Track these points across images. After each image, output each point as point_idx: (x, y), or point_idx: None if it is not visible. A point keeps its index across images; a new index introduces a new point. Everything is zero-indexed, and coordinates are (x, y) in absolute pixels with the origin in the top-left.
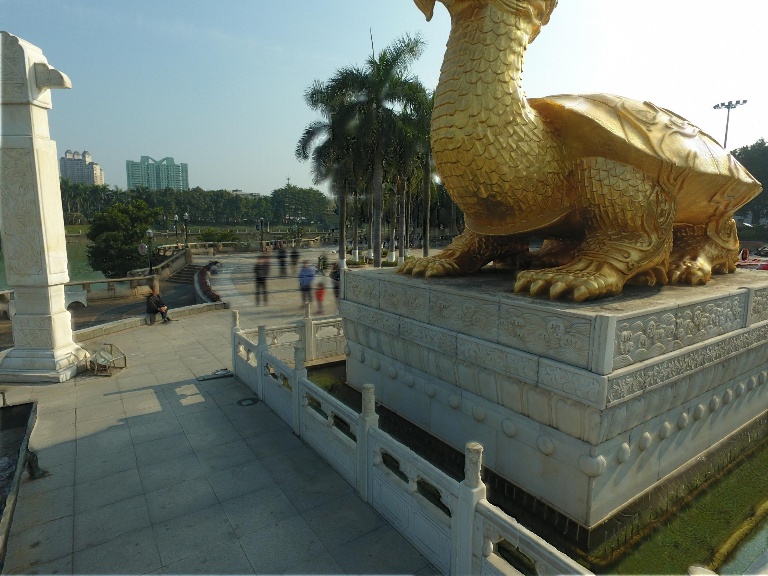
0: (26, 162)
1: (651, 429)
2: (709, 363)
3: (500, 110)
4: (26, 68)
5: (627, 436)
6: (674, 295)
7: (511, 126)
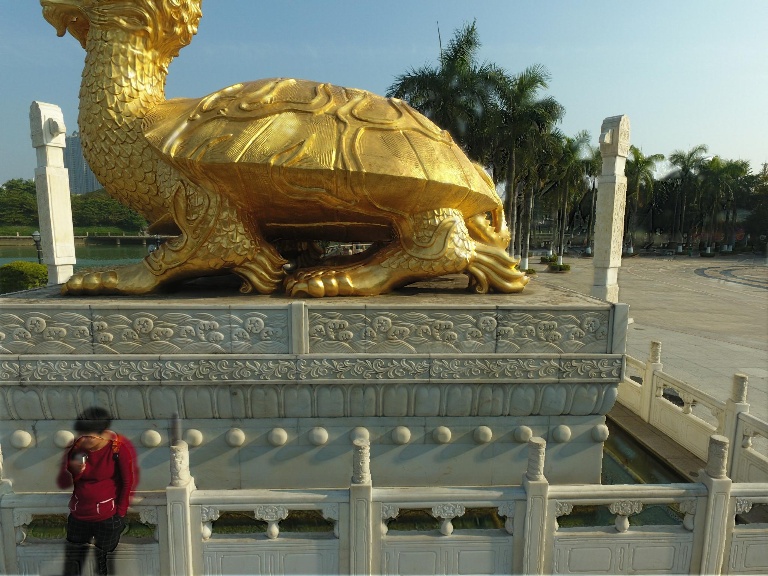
0: (45, 183)
1: (79, 430)
2: (178, 381)
3: (90, 119)
4: (42, 123)
5: (28, 425)
6: (182, 301)
7: (102, 132)
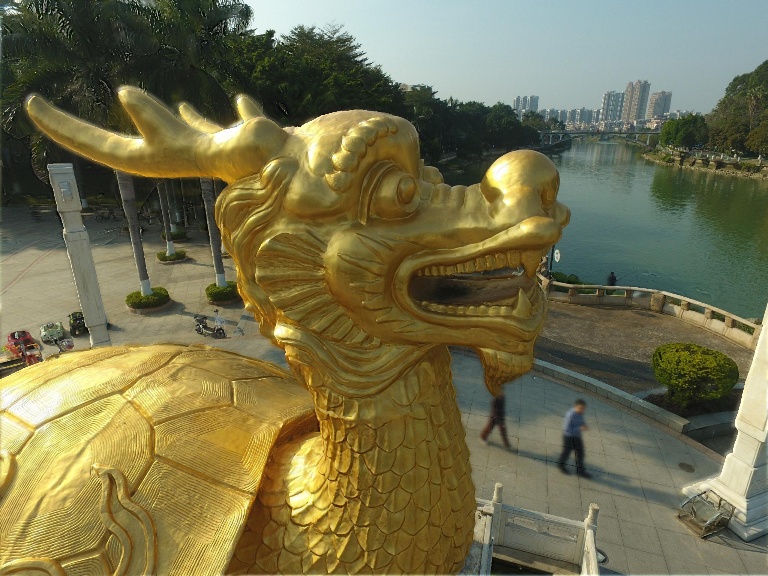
0: None
1: None
2: None
3: None
4: None
5: None
6: None
7: None
